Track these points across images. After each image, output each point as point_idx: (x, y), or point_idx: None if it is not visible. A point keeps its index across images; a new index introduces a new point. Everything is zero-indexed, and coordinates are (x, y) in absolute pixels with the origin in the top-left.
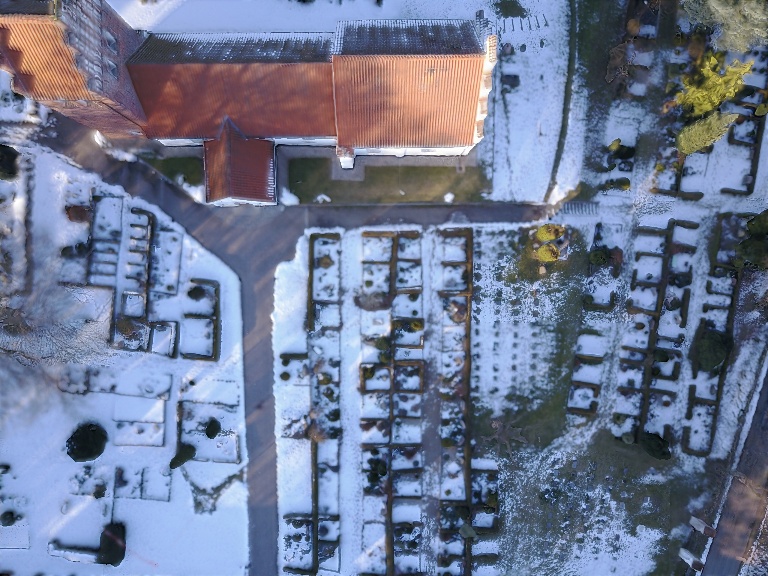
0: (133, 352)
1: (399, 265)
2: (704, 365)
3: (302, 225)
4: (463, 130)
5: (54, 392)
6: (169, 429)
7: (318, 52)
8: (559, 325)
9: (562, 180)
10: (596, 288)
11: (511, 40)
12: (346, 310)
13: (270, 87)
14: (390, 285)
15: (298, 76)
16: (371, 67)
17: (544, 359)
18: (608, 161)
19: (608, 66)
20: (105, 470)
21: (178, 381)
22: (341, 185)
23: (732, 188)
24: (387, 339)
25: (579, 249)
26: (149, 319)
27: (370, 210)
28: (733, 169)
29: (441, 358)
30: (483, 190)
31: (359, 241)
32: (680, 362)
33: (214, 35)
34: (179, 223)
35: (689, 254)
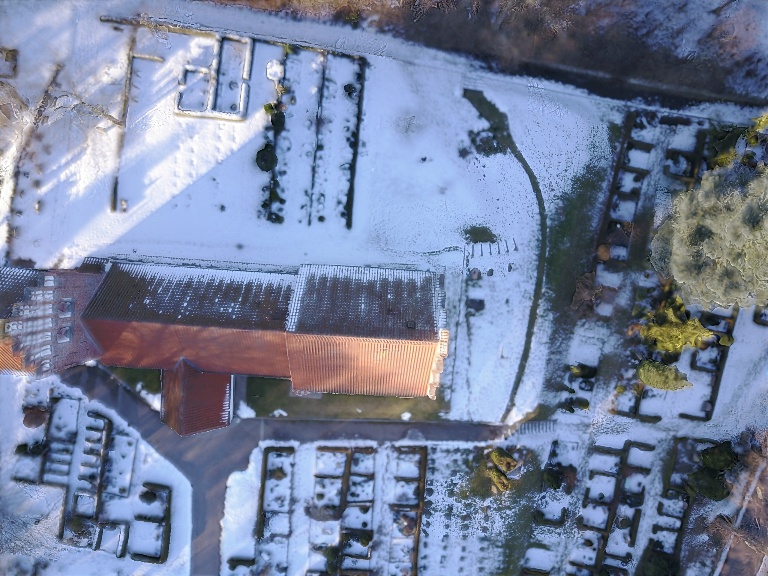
0: (81, 548)
1: (351, 479)
2: None
3: (257, 437)
4: (416, 386)
5: None
6: None
7: (275, 309)
8: (507, 541)
9: (520, 402)
10: (548, 503)
11: (479, 265)
12: (296, 519)
13: (224, 344)
14: (341, 500)
15: (252, 339)
16: (323, 344)
17: (490, 573)
18: (569, 379)
19: (574, 297)
20: None
21: None
22: (298, 401)
23: (690, 414)
24: (335, 549)
25: (533, 468)
26: (99, 520)
27: (326, 424)
28: (693, 394)
29: (388, 568)
30: (440, 410)
31: (313, 455)
32: None
33: (176, 270)
34: (134, 428)
35: (643, 475)
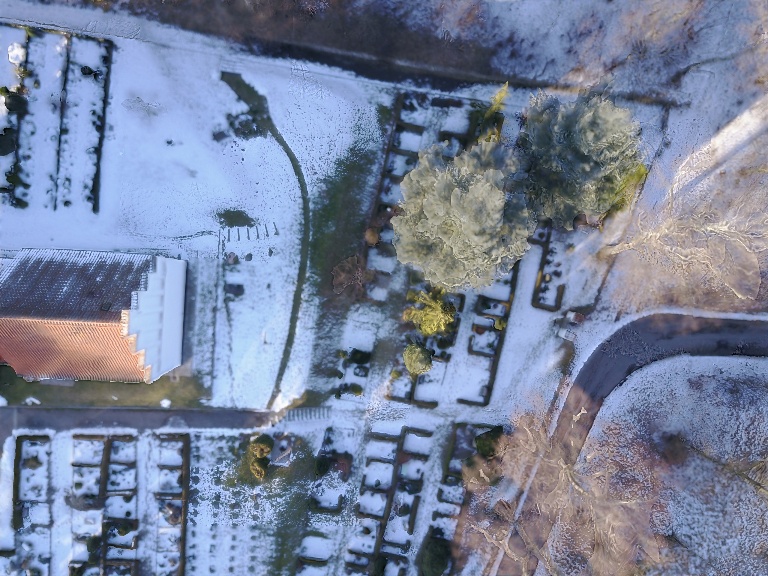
0: None
1: (111, 468)
2: (425, 575)
3: (10, 426)
4: (136, 371)
5: None
6: None
7: None
8: (279, 530)
9: (286, 388)
10: (324, 491)
11: (236, 249)
12: (57, 508)
13: None
14: (99, 489)
15: None
16: (11, 327)
17: (263, 562)
18: (343, 365)
19: (333, 281)
20: None
21: None
22: (50, 389)
23: (467, 399)
24: (97, 539)
25: (303, 455)
26: None
27: (83, 412)
28: (471, 379)
29: (156, 558)
30: (201, 397)
31: (70, 443)
32: (406, 568)
33: None
34: None
35: (421, 461)
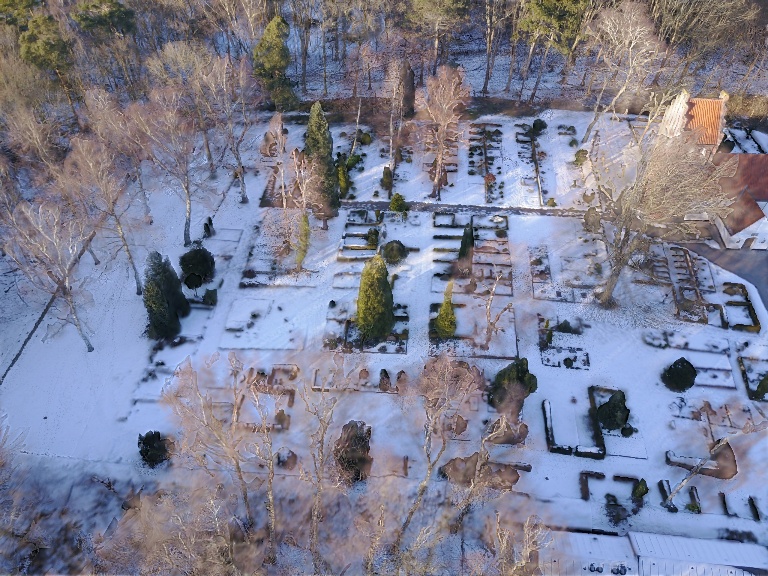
0: (694, 323)
1: None
2: None
3: None
4: None
5: (640, 346)
6: (735, 378)
7: None
8: None
9: None
10: None
11: None
12: None
13: None
14: None
15: None
16: None
17: None
18: None
19: None
20: (696, 401)
21: (733, 345)
22: None
23: None
24: None
25: None
26: (702, 302)
27: None
28: None
29: None
30: None
31: None
32: None
33: None
34: (703, 257)
35: None
